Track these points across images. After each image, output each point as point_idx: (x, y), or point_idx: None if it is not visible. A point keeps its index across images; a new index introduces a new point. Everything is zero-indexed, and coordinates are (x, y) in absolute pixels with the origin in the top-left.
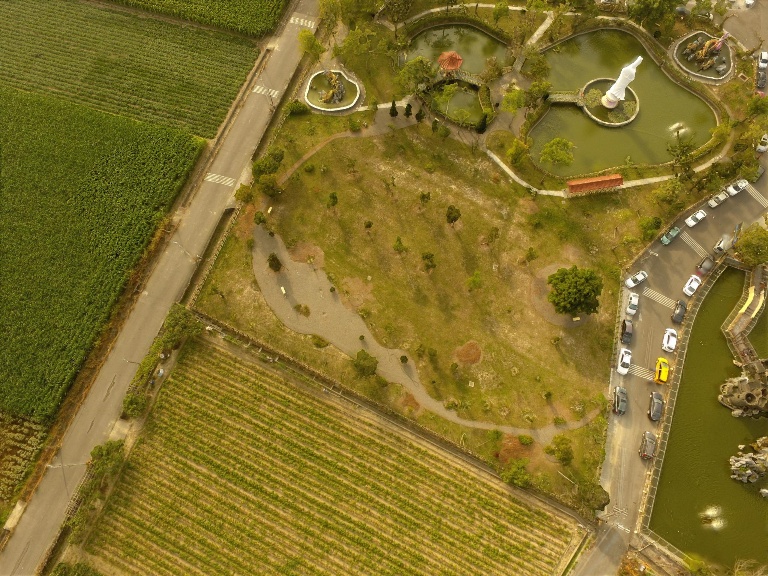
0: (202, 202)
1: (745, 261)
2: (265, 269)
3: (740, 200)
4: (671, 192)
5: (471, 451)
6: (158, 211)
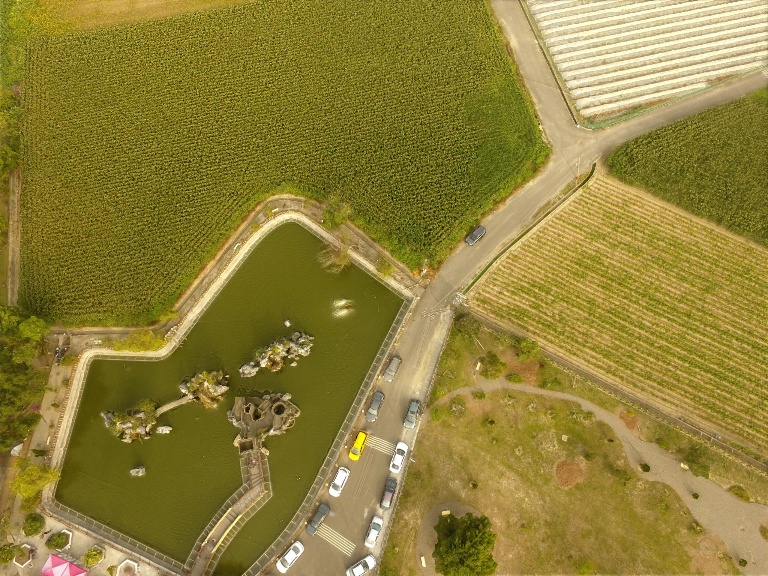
0: None
1: None
2: None
3: None
4: None
5: (566, 371)
6: None
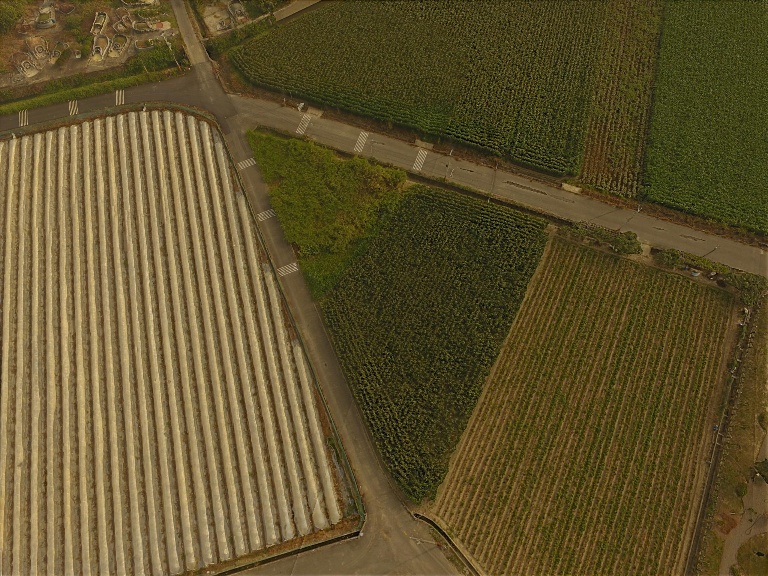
0: None
1: None
2: None
3: None
4: None
5: None
6: None
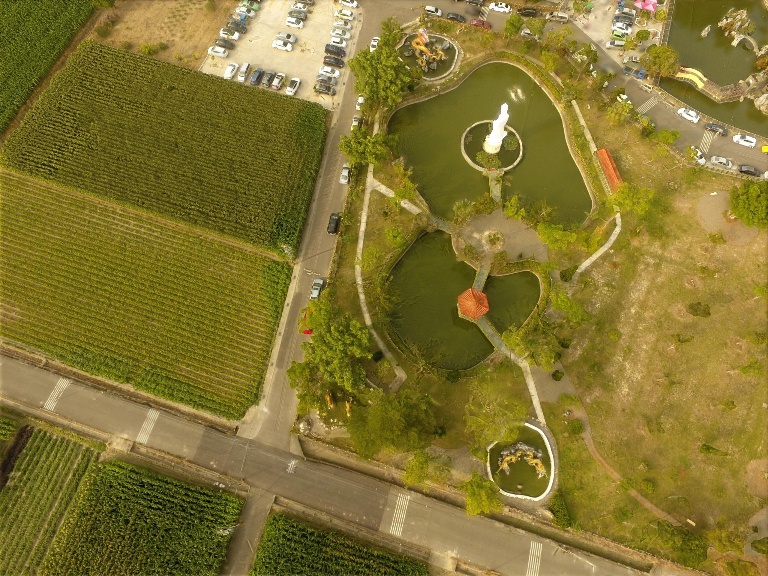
0: None
1: None
2: None
3: (593, 64)
4: None
5: None
6: None
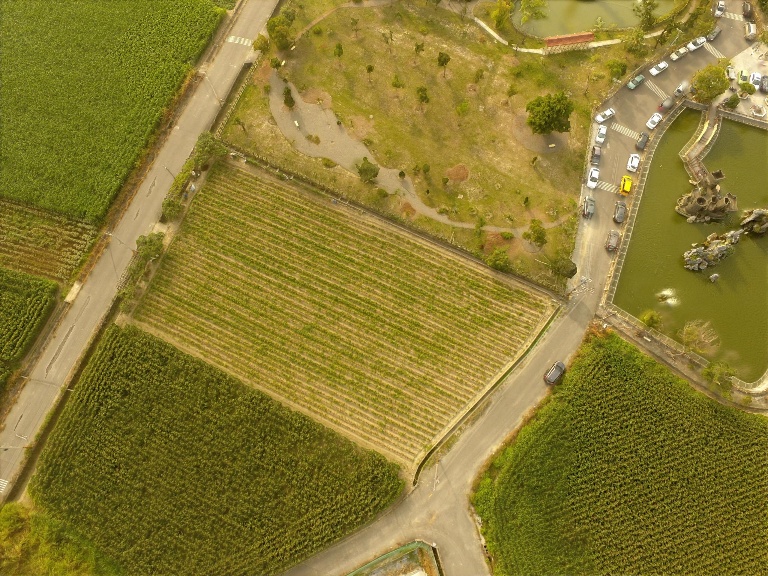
0: (224, 58)
1: (700, 95)
2: (280, 108)
3: (699, 55)
4: (636, 42)
5: (460, 244)
6: (186, 64)
